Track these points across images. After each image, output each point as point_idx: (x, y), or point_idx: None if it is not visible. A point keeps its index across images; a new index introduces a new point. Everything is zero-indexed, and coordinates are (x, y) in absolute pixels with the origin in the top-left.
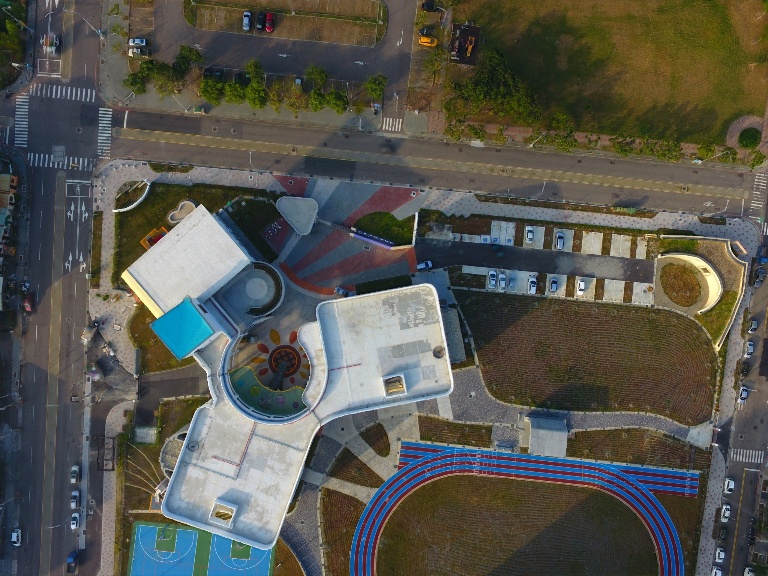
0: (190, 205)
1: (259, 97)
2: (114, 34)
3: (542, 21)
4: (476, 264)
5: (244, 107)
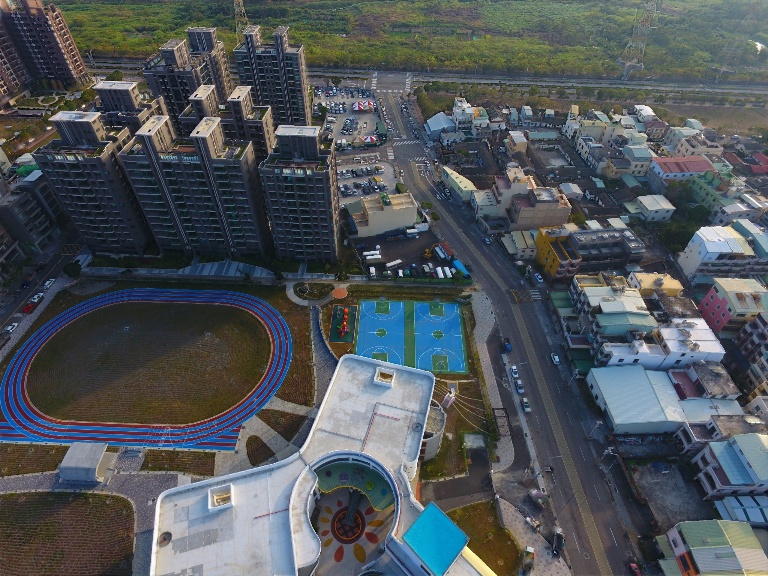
0: None
1: None
2: None
3: None
4: None
5: None
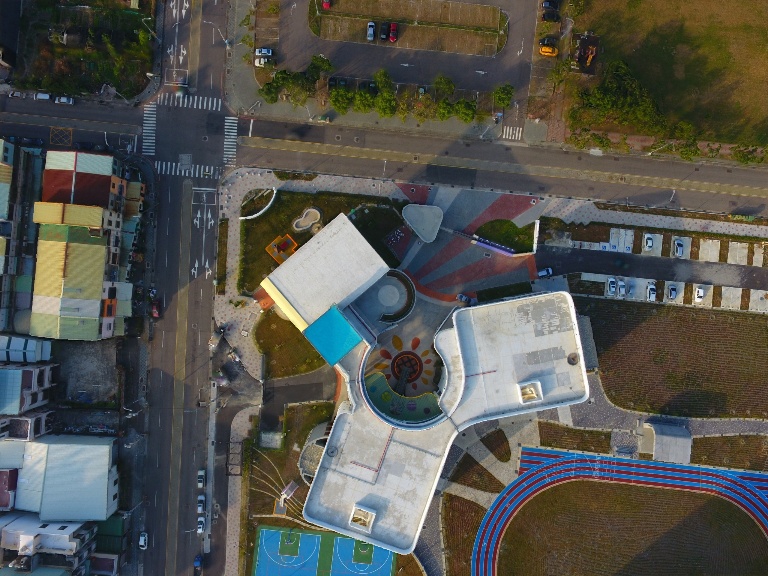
0: (314, 213)
1: (390, 106)
2: (240, 44)
3: (659, 31)
4: (595, 271)
5: (367, 116)
